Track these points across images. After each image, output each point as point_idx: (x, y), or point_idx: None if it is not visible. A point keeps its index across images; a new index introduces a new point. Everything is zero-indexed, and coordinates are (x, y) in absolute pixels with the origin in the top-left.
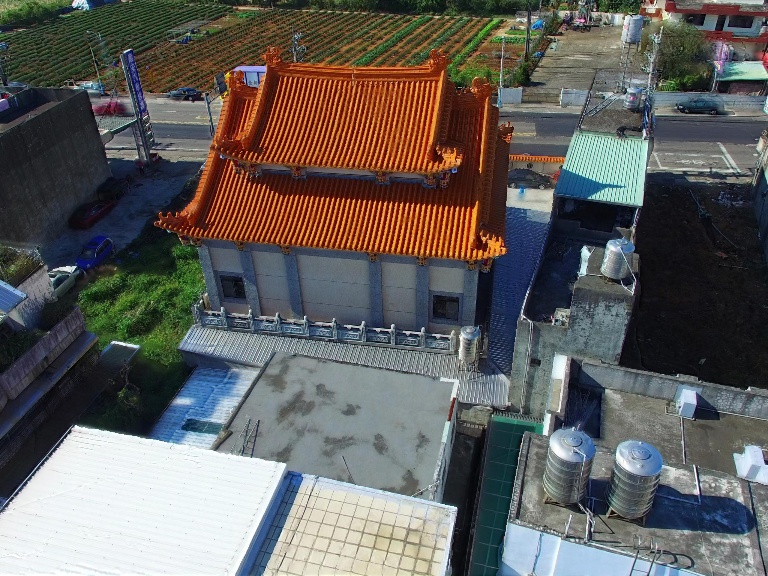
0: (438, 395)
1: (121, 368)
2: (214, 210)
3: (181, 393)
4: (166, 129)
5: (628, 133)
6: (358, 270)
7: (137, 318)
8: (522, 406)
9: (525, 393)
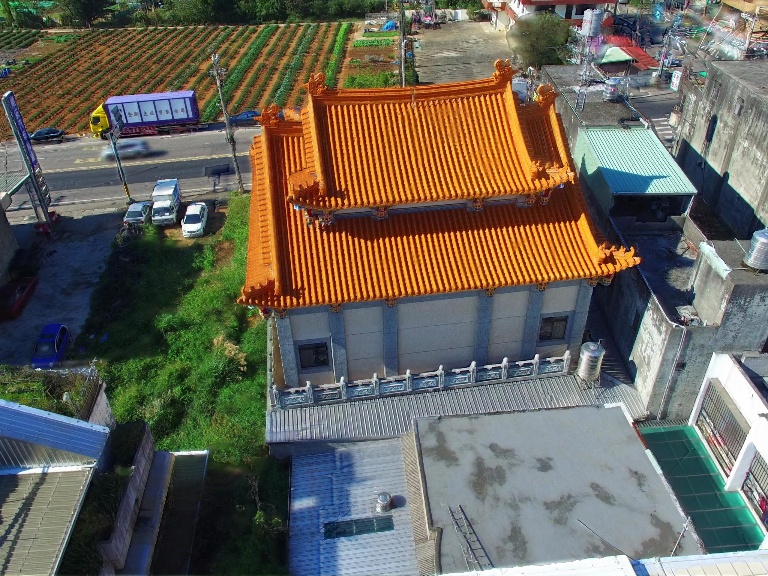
0: (615, 424)
1: (250, 488)
2: (295, 272)
3: (294, 494)
4: (45, 180)
5: (630, 124)
6: (465, 308)
7: (158, 415)
8: (661, 412)
9: (665, 398)
